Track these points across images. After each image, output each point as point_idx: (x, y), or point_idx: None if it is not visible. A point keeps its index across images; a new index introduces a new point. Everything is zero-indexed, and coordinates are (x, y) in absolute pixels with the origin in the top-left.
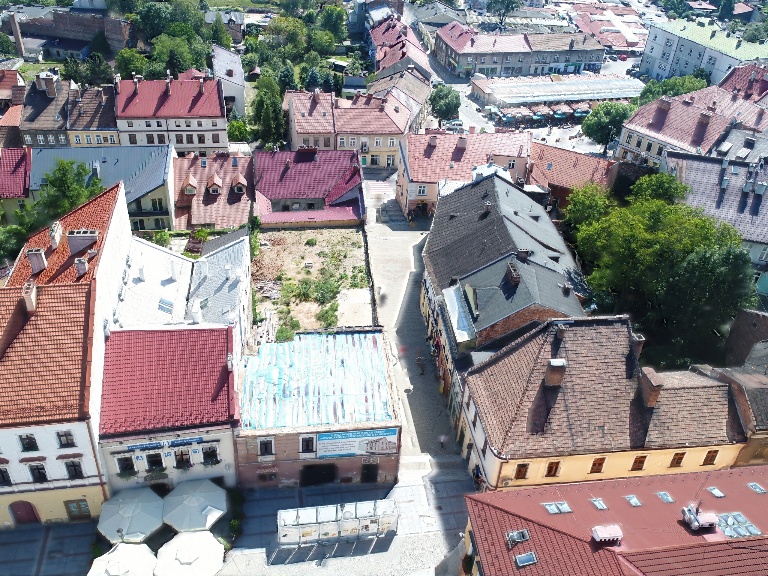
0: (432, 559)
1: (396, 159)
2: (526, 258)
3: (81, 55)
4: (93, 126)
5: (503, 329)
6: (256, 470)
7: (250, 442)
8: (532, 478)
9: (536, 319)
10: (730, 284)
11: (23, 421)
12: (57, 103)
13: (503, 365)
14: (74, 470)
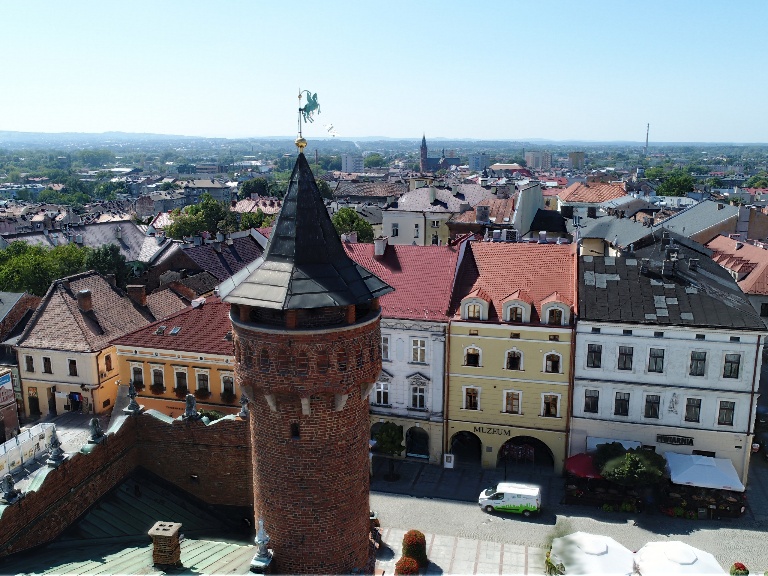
0: None
1: None
2: None
3: None
4: None
5: (11, 322)
6: None
7: None
8: (115, 368)
9: (30, 308)
10: (118, 266)
11: None
12: None
13: (42, 322)
14: None
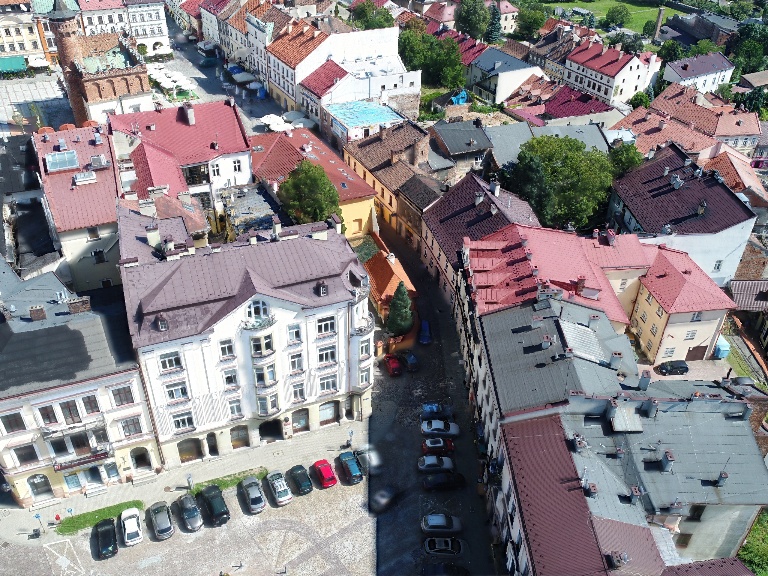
0: None
1: None
2: (480, 125)
3: (689, 49)
4: (557, 60)
5: None
6: None
7: None
8: None
9: None
10: None
11: None
12: (557, 43)
13: None
14: None
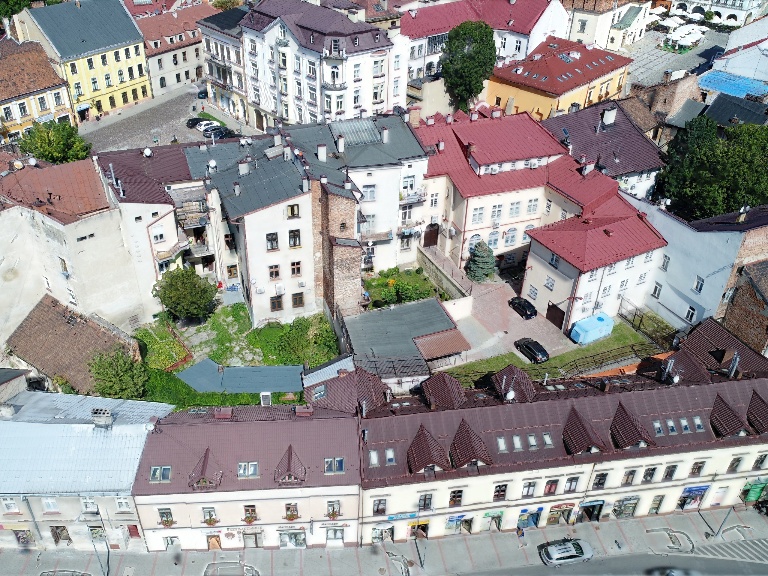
0: None
1: None
2: None
3: None
4: None
5: None
6: None
7: None
8: None
9: None
10: None
11: None
12: None
13: None
14: None
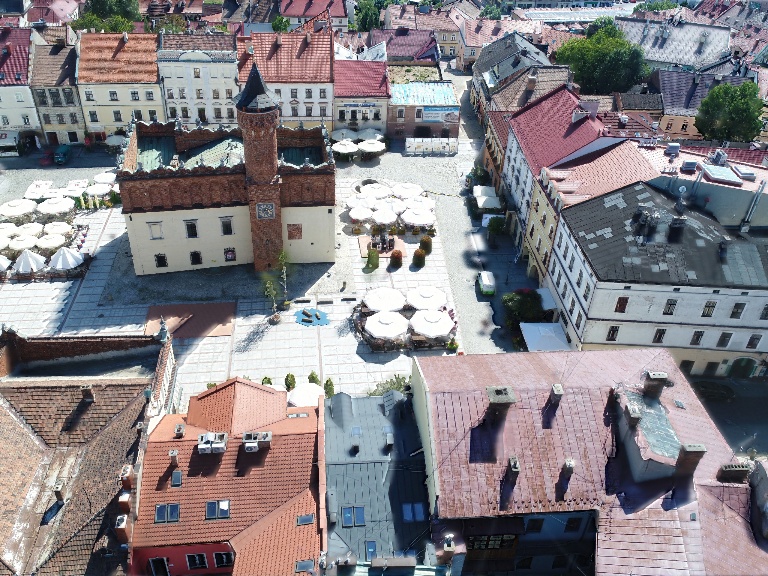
0: (473, 160)
1: (456, 49)
2: (526, 55)
3: None
4: (265, 22)
5: None
6: (395, 127)
7: (394, 109)
8: None
9: None
10: (631, 67)
11: (310, 81)
12: (243, 7)
13: (509, 87)
14: (323, 112)
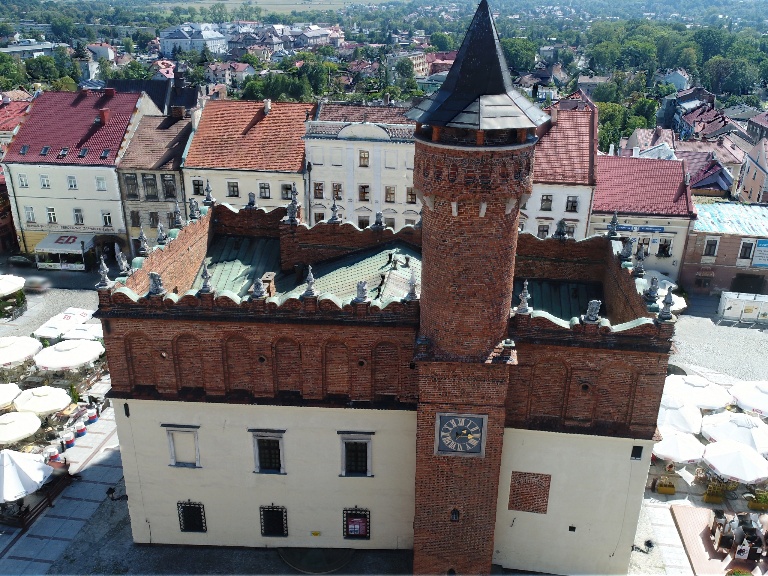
0: None
1: None
2: None
3: None
4: None
5: None
6: (696, 272)
7: (699, 240)
8: None
9: None
10: None
11: (551, 181)
12: None
13: None
14: None
